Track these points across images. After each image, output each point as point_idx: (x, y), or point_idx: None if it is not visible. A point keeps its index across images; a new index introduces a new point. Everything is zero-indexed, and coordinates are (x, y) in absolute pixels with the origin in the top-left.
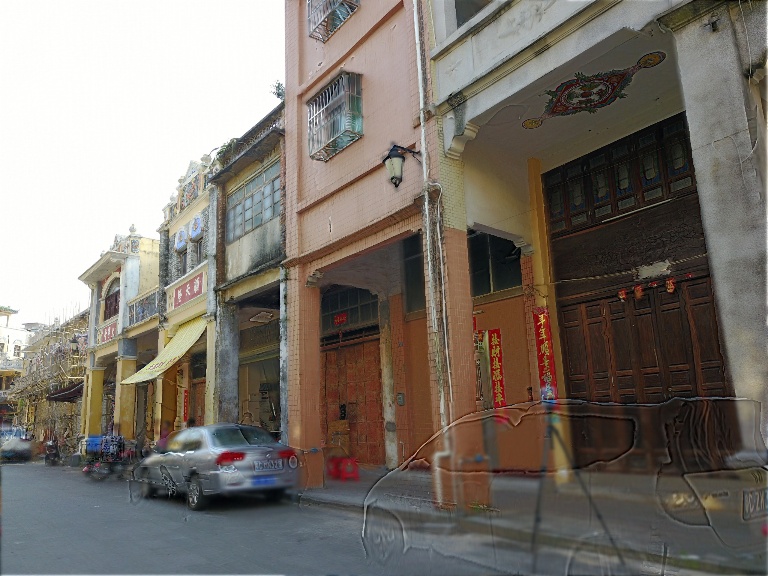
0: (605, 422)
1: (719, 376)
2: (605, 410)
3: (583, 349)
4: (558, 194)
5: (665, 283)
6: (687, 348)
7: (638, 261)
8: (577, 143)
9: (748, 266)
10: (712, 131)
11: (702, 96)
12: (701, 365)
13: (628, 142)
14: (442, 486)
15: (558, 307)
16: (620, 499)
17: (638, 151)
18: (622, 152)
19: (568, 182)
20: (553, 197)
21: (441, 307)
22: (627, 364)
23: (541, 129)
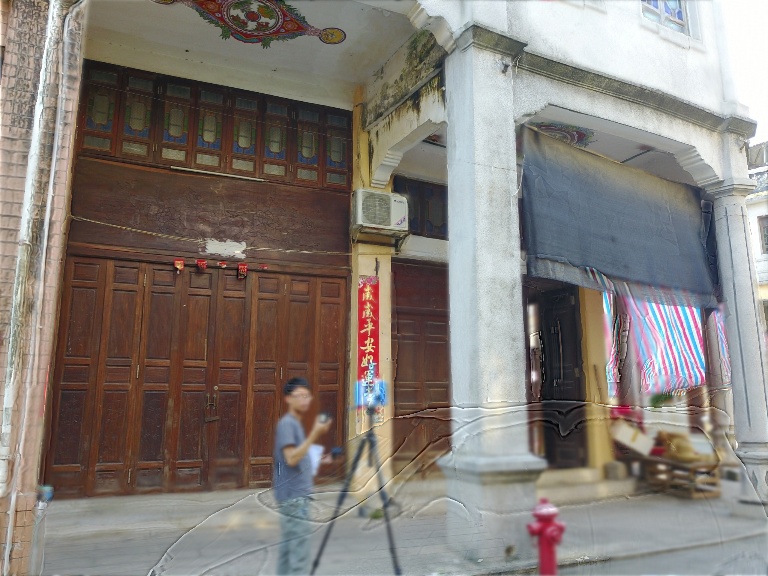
0: (677, 430)
1: (273, 378)
2: (664, 417)
3: (98, 322)
4: (106, 100)
5: (239, 267)
6: (244, 344)
7: (209, 232)
8: (156, 53)
9: (507, 287)
10: (494, 156)
11: (488, 120)
12: (256, 364)
13: (226, 93)
14: (507, 542)
15: (68, 254)
16: (745, 512)
17: (235, 110)
18: (215, 100)
19: (128, 93)
20: (97, 99)
21: (41, 199)
22: (164, 352)
23: (156, 8)
